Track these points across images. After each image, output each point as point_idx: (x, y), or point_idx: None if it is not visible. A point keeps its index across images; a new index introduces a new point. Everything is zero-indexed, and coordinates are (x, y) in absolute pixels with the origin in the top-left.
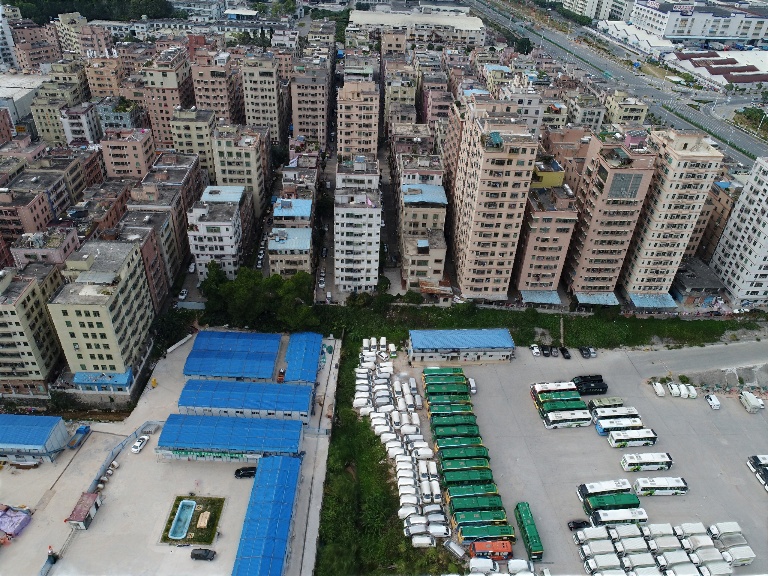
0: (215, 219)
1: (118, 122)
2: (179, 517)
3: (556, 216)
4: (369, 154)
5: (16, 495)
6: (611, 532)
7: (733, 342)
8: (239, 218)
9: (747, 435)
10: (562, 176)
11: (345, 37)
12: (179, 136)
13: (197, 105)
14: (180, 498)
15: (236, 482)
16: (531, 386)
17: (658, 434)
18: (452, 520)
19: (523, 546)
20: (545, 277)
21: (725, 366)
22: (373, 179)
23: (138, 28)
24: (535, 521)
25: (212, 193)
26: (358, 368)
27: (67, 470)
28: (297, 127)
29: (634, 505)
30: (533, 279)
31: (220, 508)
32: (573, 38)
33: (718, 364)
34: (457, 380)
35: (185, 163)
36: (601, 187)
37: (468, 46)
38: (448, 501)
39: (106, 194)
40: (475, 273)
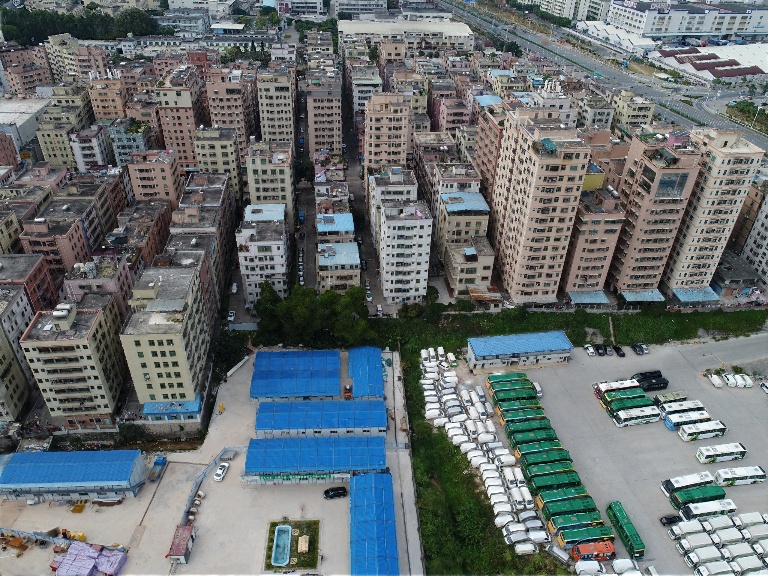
0: (265, 238)
1: (131, 144)
2: (277, 543)
3: (605, 218)
4: (399, 165)
5: (106, 534)
6: (704, 525)
7: None
8: (285, 236)
9: None
10: (602, 178)
11: (344, 48)
12: (204, 156)
13: (212, 123)
14: (275, 524)
15: (327, 503)
16: (595, 386)
17: None
18: (549, 525)
19: (622, 545)
20: (592, 278)
21: None
22: (412, 190)
23: (125, 46)
24: None
25: (255, 212)
26: (423, 379)
27: (152, 504)
28: (313, 140)
29: (720, 496)
30: (580, 280)
31: (317, 531)
32: (555, 39)
33: (766, 352)
34: (524, 385)
35: (217, 183)
36: (647, 187)
37: (457, 52)
38: (541, 506)
39: (142, 218)
40: (526, 278)
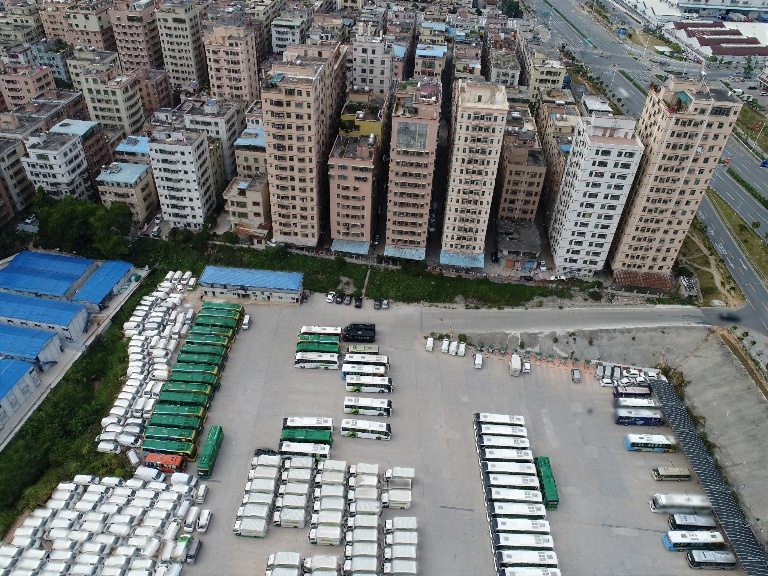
0: (46, 148)
1: (51, 63)
2: None
3: (351, 164)
4: (241, 100)
5: None
6: (286, 462)
7: (534, 308)
8: (80, 150)
9: (494, 395)
10: (379, 126)
11: None
12: (77, 75)
13: (118, 49)
14: None
15: None
16: (300, 328)
17: (402, 384)
18: None
19: None
20: (355, 227)
21: (511, 329)
22: (219, 122)
23: None
24: (227, 445)
25: (62, 125)
26: (147, 296)
27: None
28: None
29: (325, 442)
30: (343, 228)
31: None
32: None
33: (505, 327)
34: (228, 315)
35: (65, 99)
36: None
37: (455, 8)
38: None
39: None
40: (281, 217)
